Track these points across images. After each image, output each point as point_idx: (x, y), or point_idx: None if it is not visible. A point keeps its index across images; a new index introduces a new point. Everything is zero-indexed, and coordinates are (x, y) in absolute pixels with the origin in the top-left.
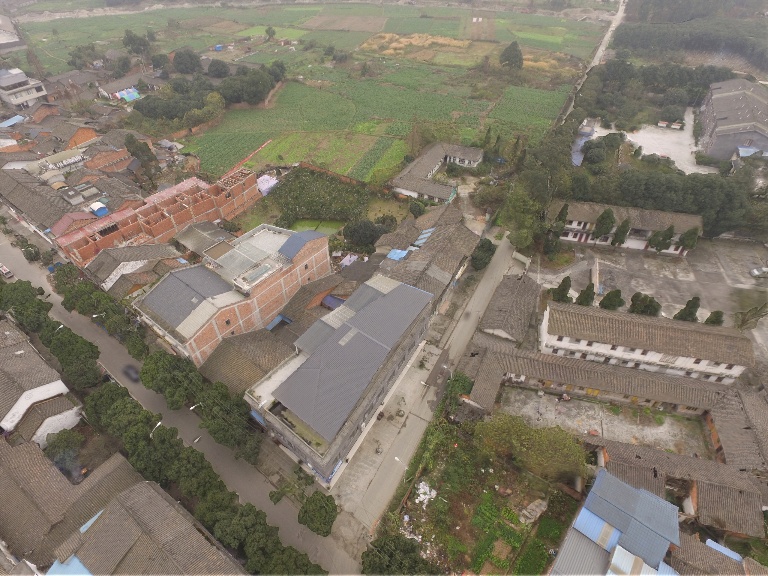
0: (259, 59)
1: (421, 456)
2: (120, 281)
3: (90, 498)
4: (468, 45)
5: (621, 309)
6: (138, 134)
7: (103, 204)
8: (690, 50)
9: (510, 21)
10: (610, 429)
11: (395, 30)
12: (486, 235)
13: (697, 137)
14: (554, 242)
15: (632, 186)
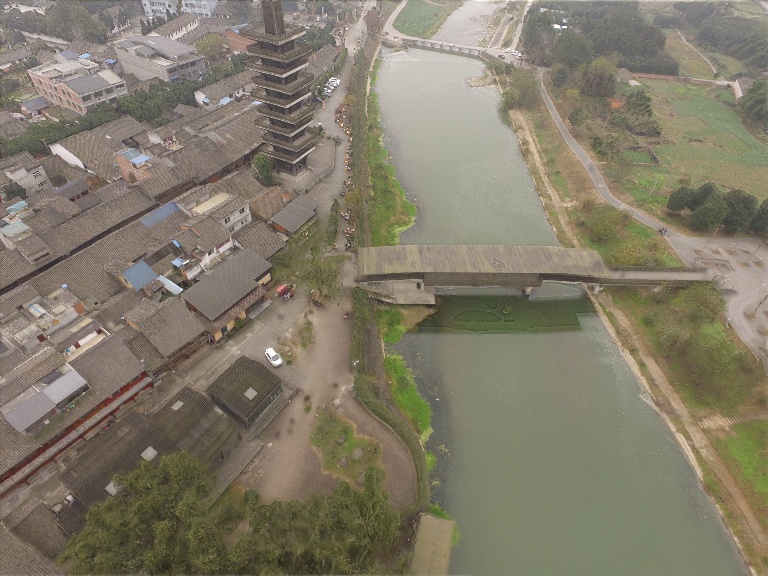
0: None
1: None
2: None
3: None
4: None
5: None
6: None
7: None
8: None
9: None
10: None
11: None
12: None
13: (32, 5)
14: None
15: (87, 2)
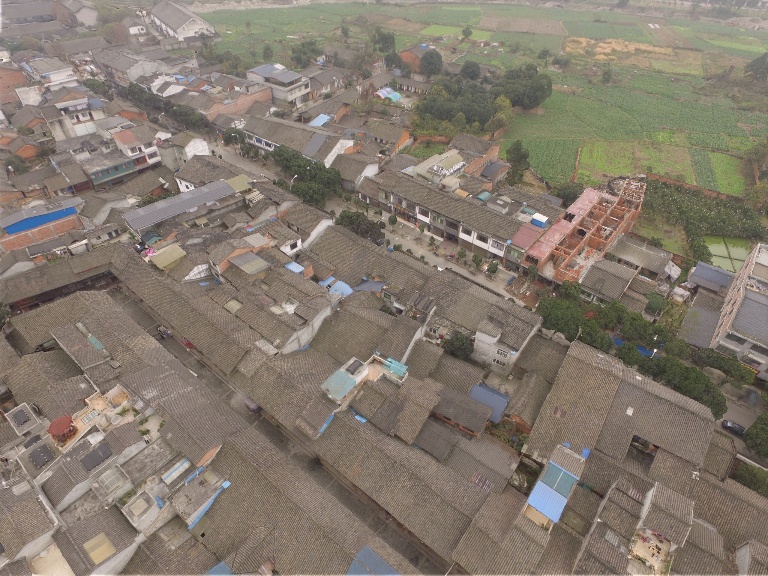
0: (476, 60)
1: None
2: (624, 299)
3: None
4: (674, 53)
5: None
6: None
7: None
8: None
9: (690, 28)
10: None
11: (582, 34)
12: None
13: None
14: None
15: None
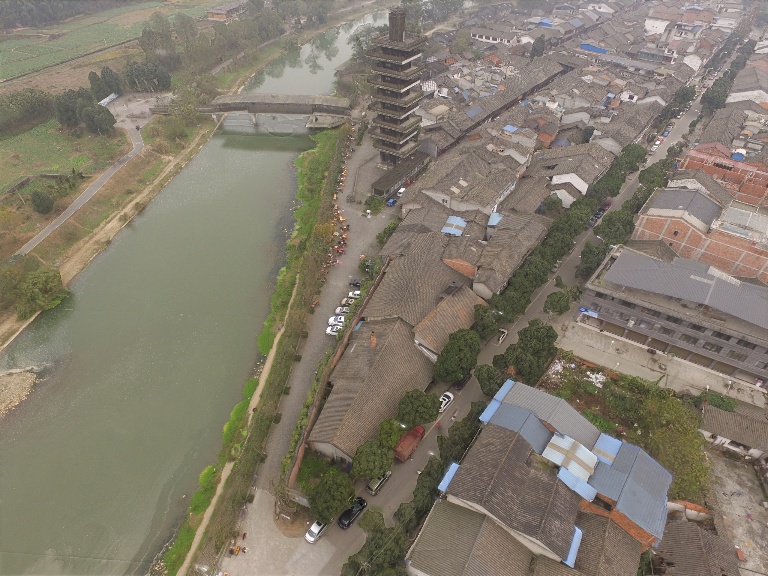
0: None
1: None
2: None
3: None
4: None
5: None
6: None
7: None
8: None
9: None
10: None
11: None
12: None
13: None
14: None
15: None
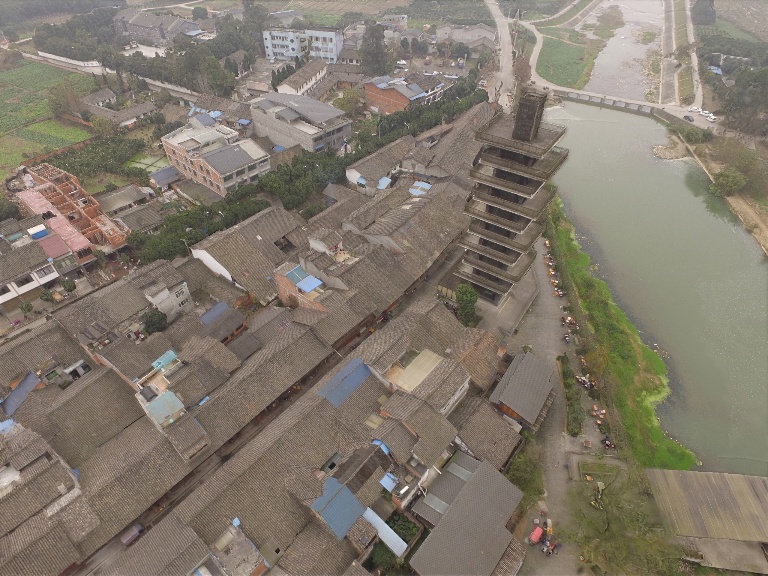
0: None
1: None
2: (163, 217)
3: None
4: None
5: None
6: None
7: None
8: (29, 19)
9: None
10: None
11: None
12: None
13: (151, 45)
14: None
15: (214, 48)
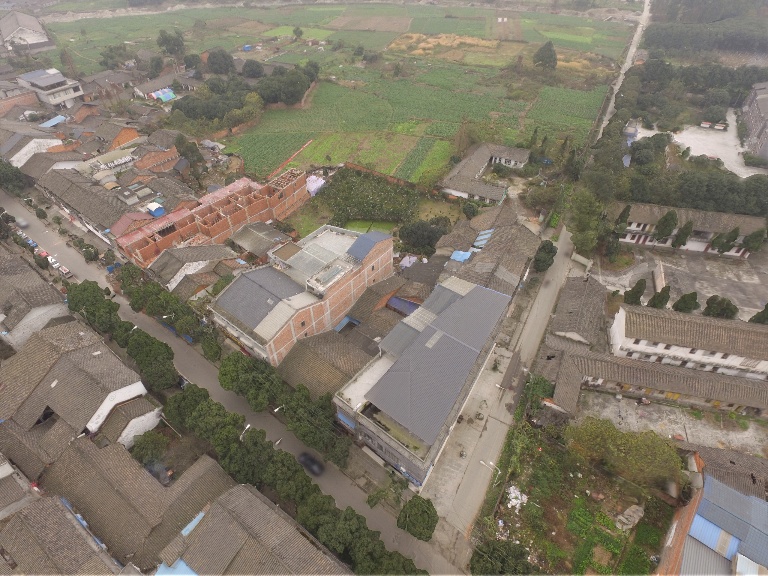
0: (289, 59)
1: (506, 460)
2: (184, 282)
3: (185, 500)
4: (497, 45)
5: (696, 312)
6: (183, 134)
7: (159, 204)
8: (723, 50)
9: (536, 21)
10: (694, 434)
11: (421, 30)
12: (542, 236)
13: (742, 138)
14: (615, 244)
15: (693, 187)
